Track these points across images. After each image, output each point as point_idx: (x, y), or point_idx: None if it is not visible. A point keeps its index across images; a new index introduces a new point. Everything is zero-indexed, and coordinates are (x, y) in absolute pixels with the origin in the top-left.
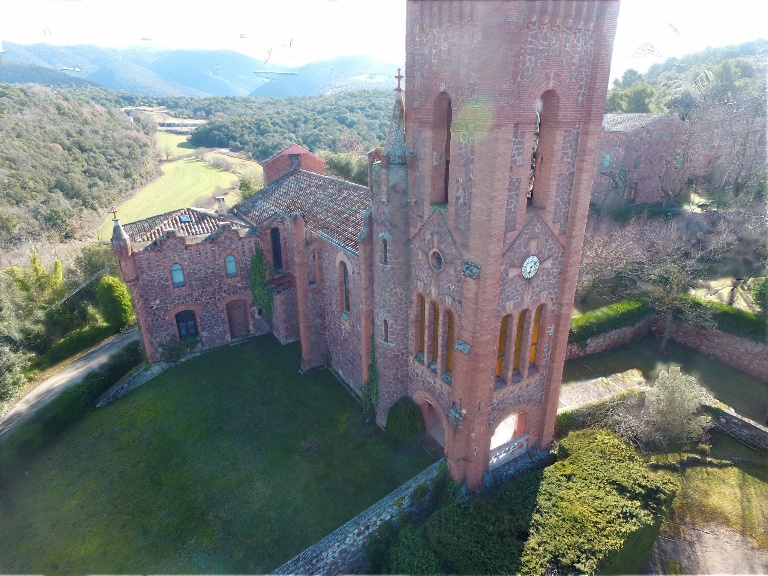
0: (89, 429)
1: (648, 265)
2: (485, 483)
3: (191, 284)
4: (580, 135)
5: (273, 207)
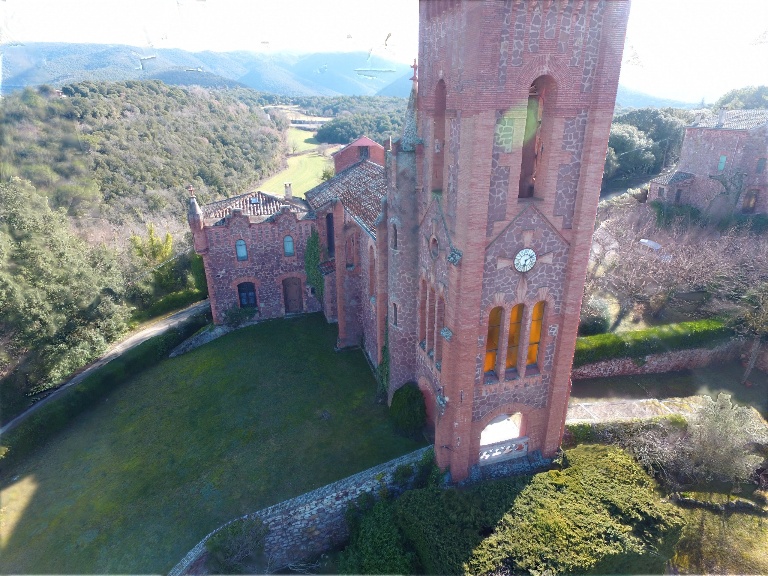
0: (159, 373)
1: (739, 282)
2: (472, 477)
3: (253, 259)
4: (587, 123)
5: (332, 194)
